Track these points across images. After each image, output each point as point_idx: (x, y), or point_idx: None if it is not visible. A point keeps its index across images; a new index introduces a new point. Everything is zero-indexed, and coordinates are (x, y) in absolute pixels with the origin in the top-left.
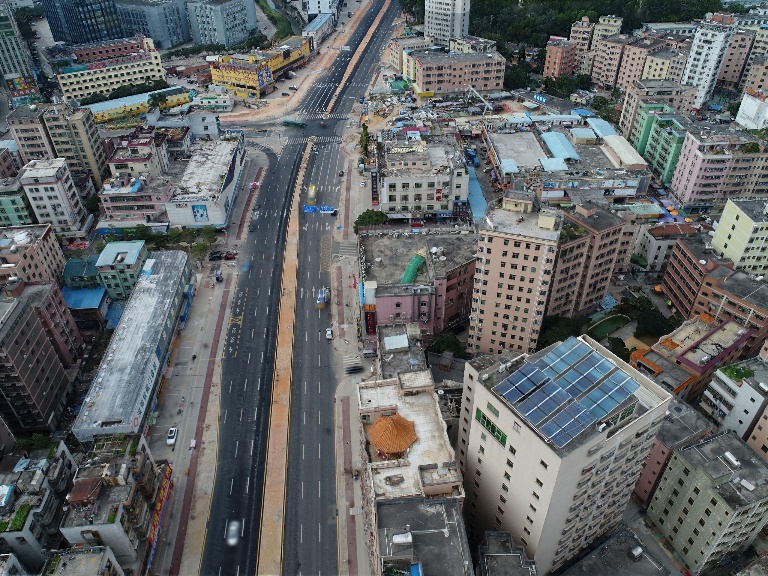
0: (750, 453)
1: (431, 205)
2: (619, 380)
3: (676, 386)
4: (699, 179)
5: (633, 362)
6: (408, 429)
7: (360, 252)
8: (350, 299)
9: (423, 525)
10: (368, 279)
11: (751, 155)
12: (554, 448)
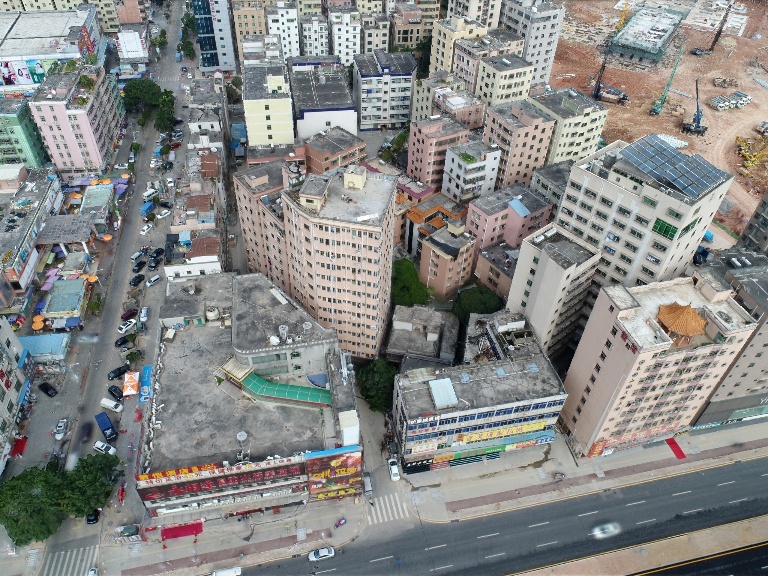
0: (549, 168)
1: (8, 403)
2: (653, 141)
3: (453, 203)
4: (95, 135)
5: (422, 223)
6: (672, 307)
7: (209, 470)
8: (231, 536)
9: (760, 292)
10: (280, 454)
11: (96, 87)
12: (728, 178)
